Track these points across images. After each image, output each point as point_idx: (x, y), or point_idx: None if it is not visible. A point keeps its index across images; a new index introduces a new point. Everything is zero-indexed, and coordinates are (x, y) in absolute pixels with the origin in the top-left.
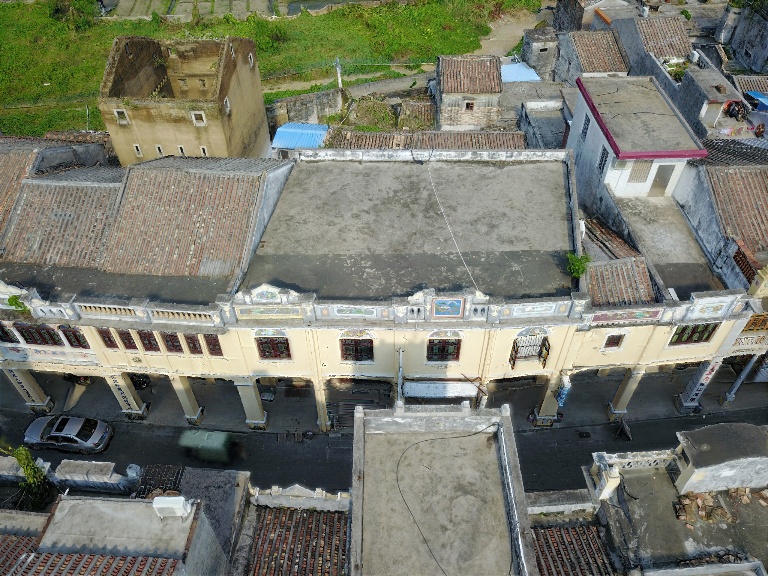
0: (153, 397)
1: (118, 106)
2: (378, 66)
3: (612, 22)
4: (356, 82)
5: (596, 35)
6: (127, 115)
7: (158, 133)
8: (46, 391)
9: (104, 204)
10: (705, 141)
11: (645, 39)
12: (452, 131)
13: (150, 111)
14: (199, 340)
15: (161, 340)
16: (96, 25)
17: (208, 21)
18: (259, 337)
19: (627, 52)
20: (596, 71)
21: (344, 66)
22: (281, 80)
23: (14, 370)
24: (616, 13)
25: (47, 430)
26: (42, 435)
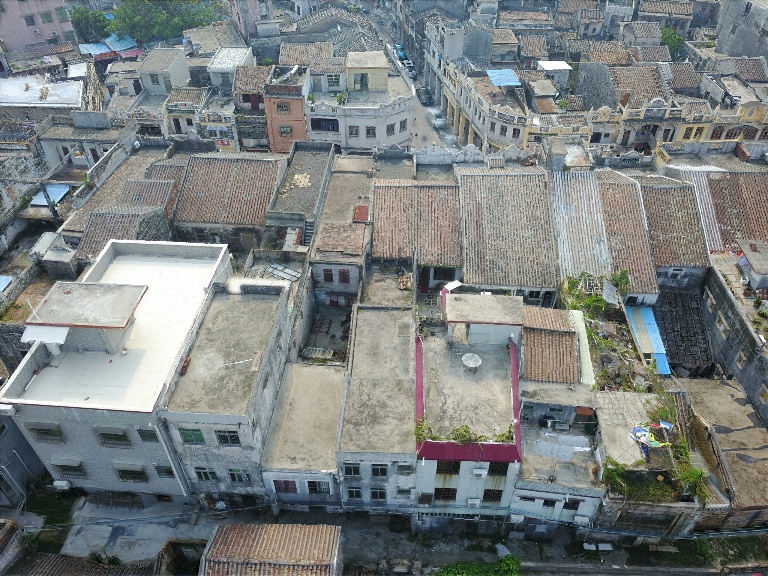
0: None
1: None
2: None
3: None
4: None
5: None
6: None
7: None
8: None
9: None
10: None
11: None
12: None
13: None
14: None
15: None
16: None
17: None
18: None
19: None
20: None
21: None
22: None
23: None
24: None
25: None
26: None
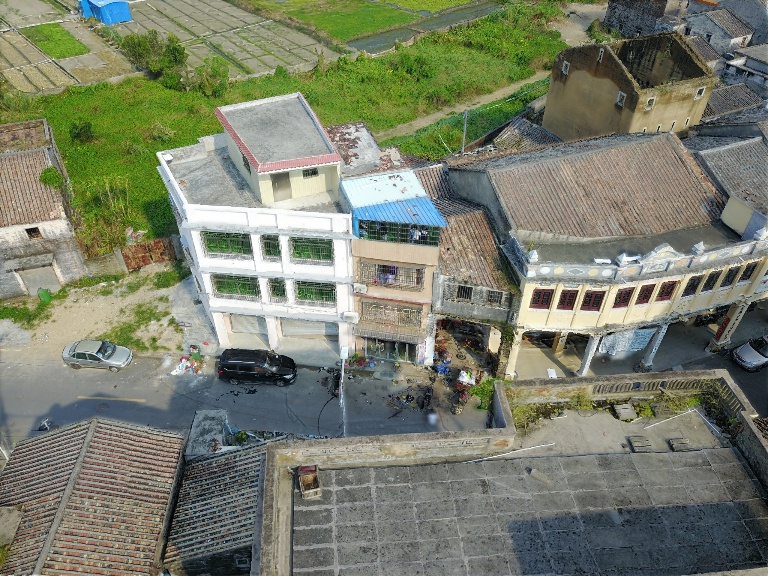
0: (767, 311)
1: (653, 94)
2: (527, 72)
3: (720, 3)
4: (538, 84)
5: (719, 13)
6: (655, 101)
7: (666, 113)
8: (697, 338)
9: (764, 153)
10: None
11: (767, 8)
12: None
13: (672, 94)
14: None
15: None
16: (227, 88)
17: (329, 66)
18: None
19: (747, 20)
20: (739, 36)
21: (509, 76)
22: (470, 97)
23: (747, 305)
24: None
25: (762, 351)
26: (764, 355)
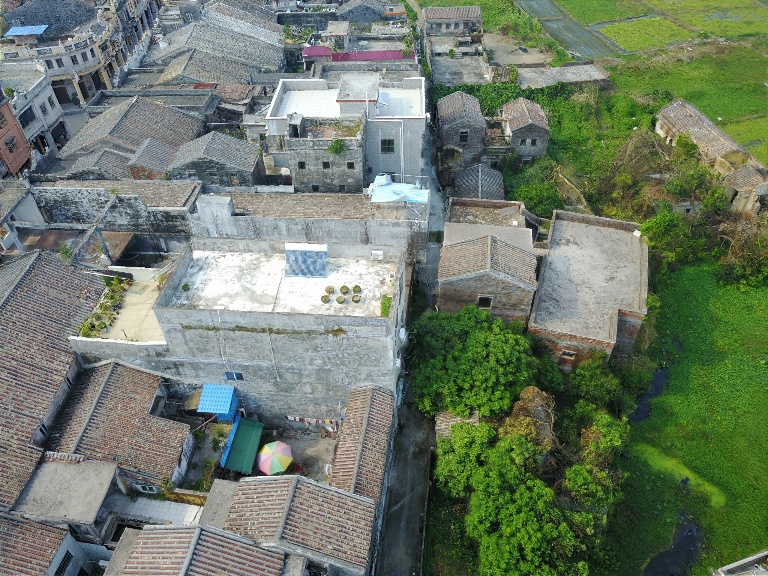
0: None
1: None
2: None
3: None
4: None
5: None
6: None
7: None
8: None
9: None
10: (260, 6)
11: None
12: (322, 1)
13: None
14: None
15: None
16: None
17: None
18: None
19: None
20: None
21: None
22: None
23: None
24: (397, 8)
25: None
26: None
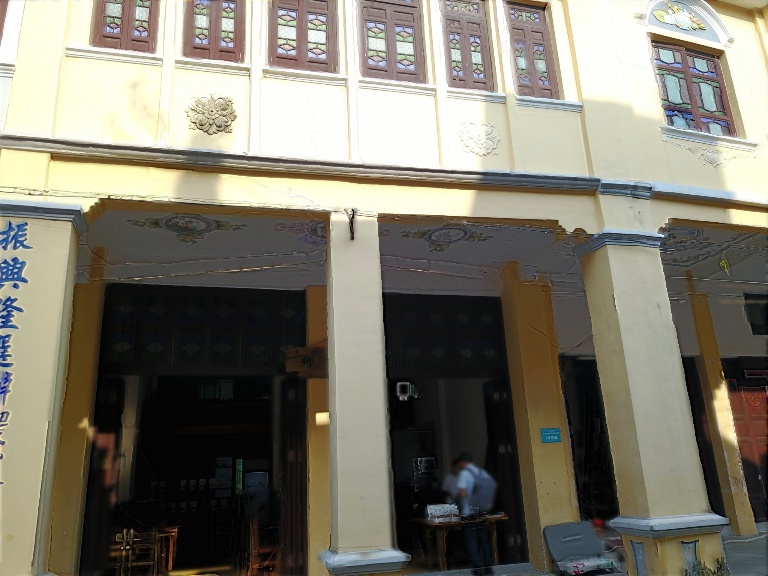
0: None
1: None
2: None
3: None
4: None
5: None
6: None
7: None
8: None
9: None
10: None
11: None
12: None
13: None
14: (495, 15)
15: (354, 19)
16: None
17: None
18: (655, 40)
19: None
20: None
21: None
22: None
23: None
24: None
25: None
26: None
